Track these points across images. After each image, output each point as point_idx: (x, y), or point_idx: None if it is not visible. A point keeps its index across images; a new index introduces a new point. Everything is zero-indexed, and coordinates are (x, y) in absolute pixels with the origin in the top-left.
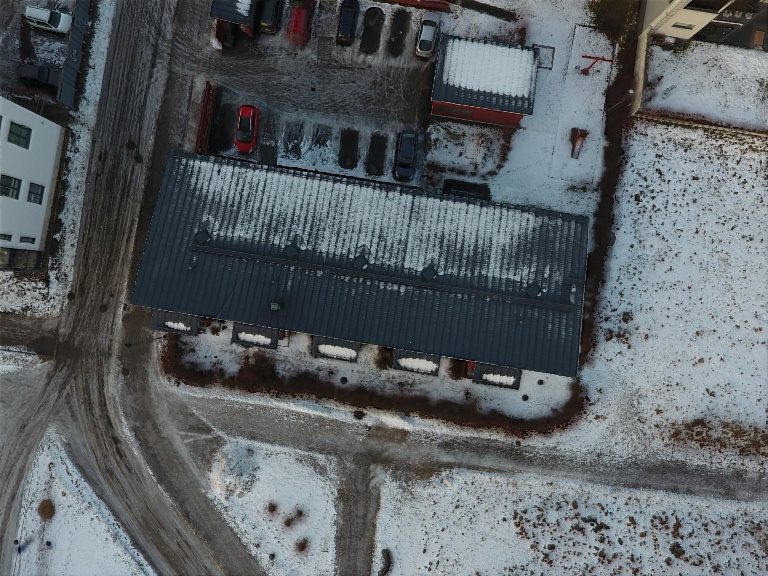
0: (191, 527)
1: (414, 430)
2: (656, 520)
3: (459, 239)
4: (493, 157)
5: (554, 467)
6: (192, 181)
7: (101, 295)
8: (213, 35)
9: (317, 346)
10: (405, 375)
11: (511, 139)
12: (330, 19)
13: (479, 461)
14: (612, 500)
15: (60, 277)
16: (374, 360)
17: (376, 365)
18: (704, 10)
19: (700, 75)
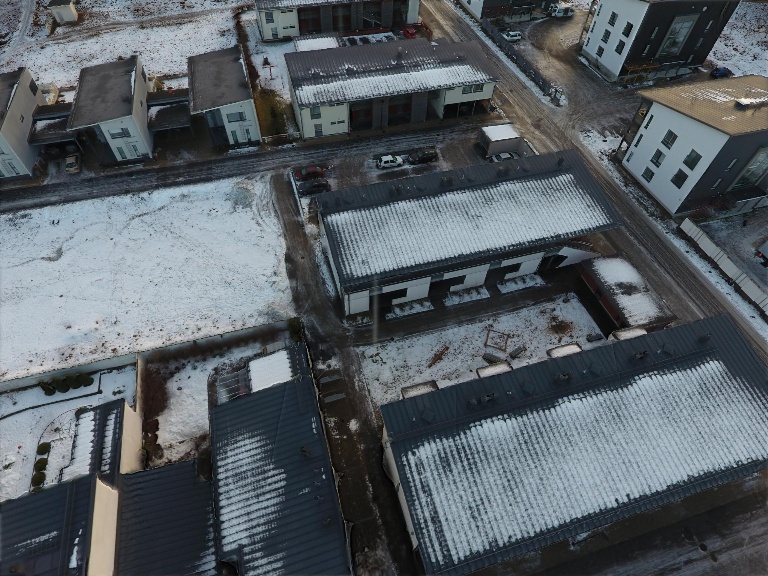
0: None
1: None
2: (192, 7)
3: None
4: None
5: None
6: None
7: (432, 1)
8: None
9: None
10: None
11: None
12: None
13: None
14: None
15: None
16: None
17: None
18: None
19: None
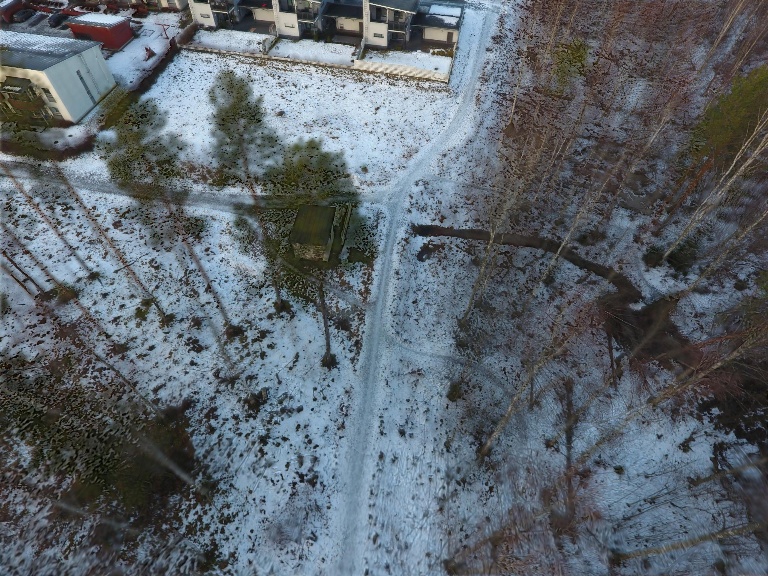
0: None
1: None
2: (112, 209)
3: (27, 41)
4: None
5: (56, 178)
6: None
7: None
8: None
9: None
10: None
11: (114, 54)
12: None
13: (6, 172)
14: (87, 198)
15: None
16: None
17: None
18: (203, 3)
19: (219, 38)
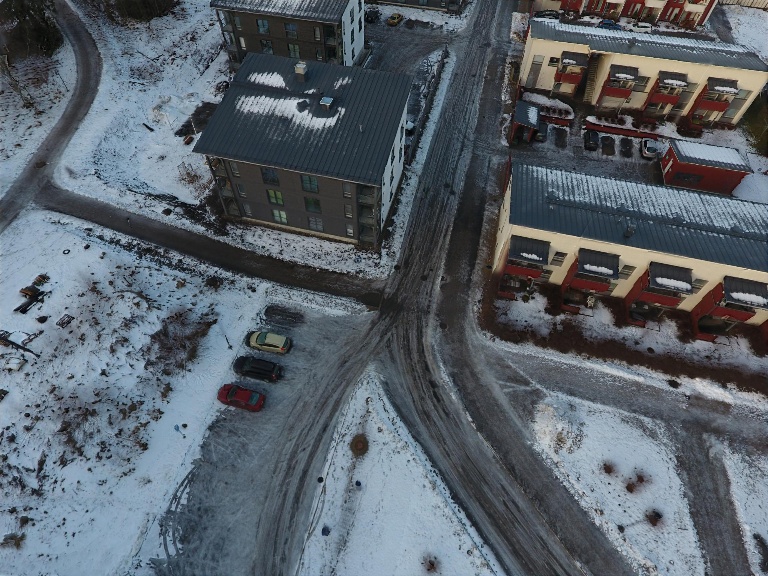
0: (518, 484)
1: (736, 404)
2: None
3: (748, 216)
4: None
5: None
6: (534, 174)
7: (422, 269)
8: (502, 140)
9: (654, 278)
10: (710, 349)
11: None
12: (578, 139)
13: None
14: None
15: (390, 254)
16: (675, 335)
17: (678, 340)
18: None
19: None
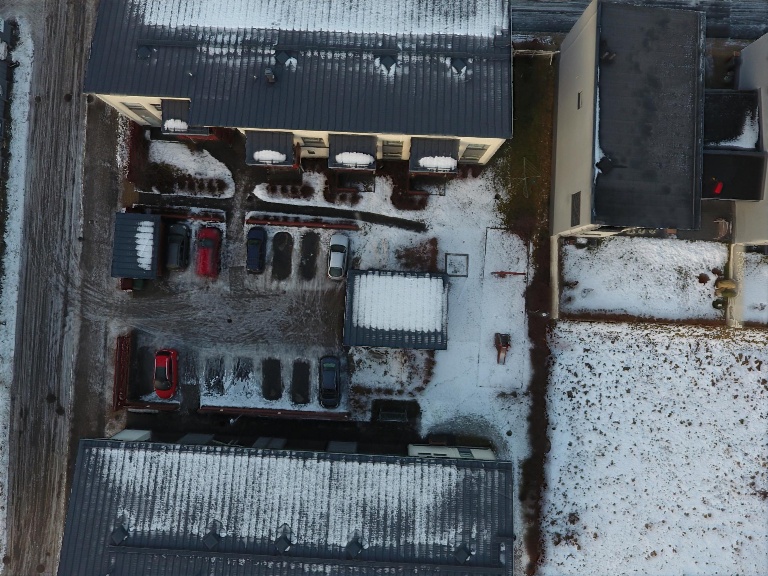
0: None
1: None
2: None
3: (381, 505)
4: (418, 373)
5: None
6: (104, 473)
7: (37, 555)
8: None
9: None
10: None
11: (434, 352)
12: (238, 248)
13: None
14: None
15: None
16: None
17: None
18: (607, 230)
19: (617, 270)
